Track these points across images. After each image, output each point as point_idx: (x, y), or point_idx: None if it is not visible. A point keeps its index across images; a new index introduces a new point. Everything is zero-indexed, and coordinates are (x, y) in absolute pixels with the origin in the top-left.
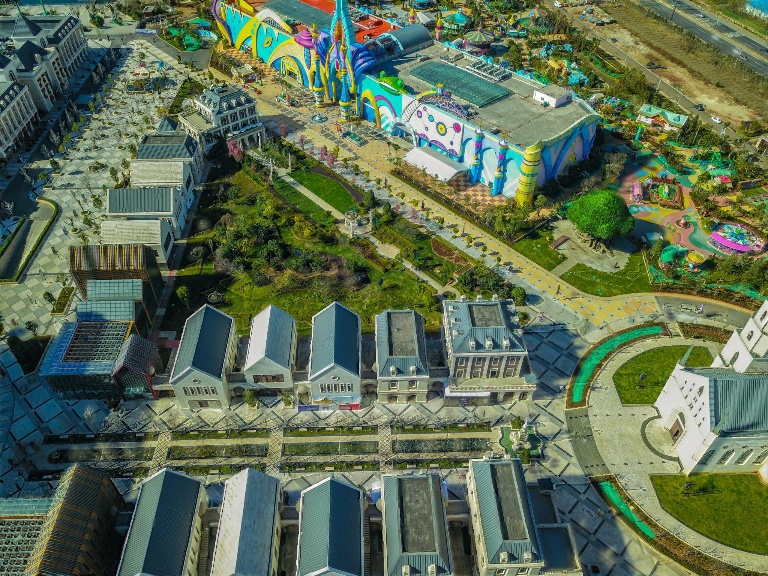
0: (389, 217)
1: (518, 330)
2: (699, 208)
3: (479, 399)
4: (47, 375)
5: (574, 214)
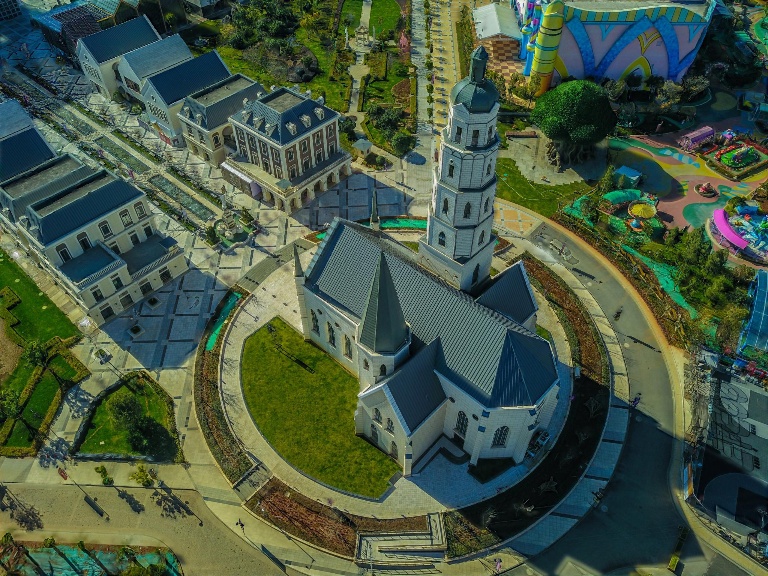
0: (399, 50)
1: (291, 124)
2: (761, 189)
3: (243, 183)
4: (35, 18)
5: (540, 99)
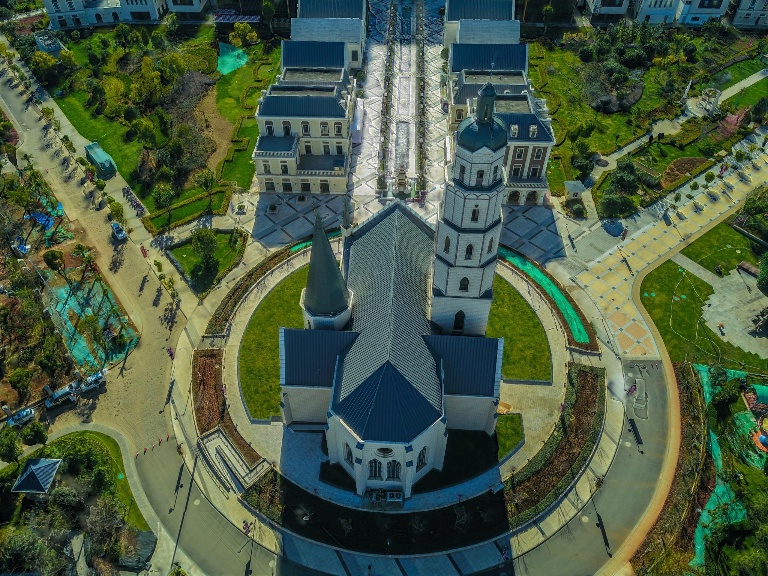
0: (736, 130)
1: None
2: None
3: None
4: None
5: None
